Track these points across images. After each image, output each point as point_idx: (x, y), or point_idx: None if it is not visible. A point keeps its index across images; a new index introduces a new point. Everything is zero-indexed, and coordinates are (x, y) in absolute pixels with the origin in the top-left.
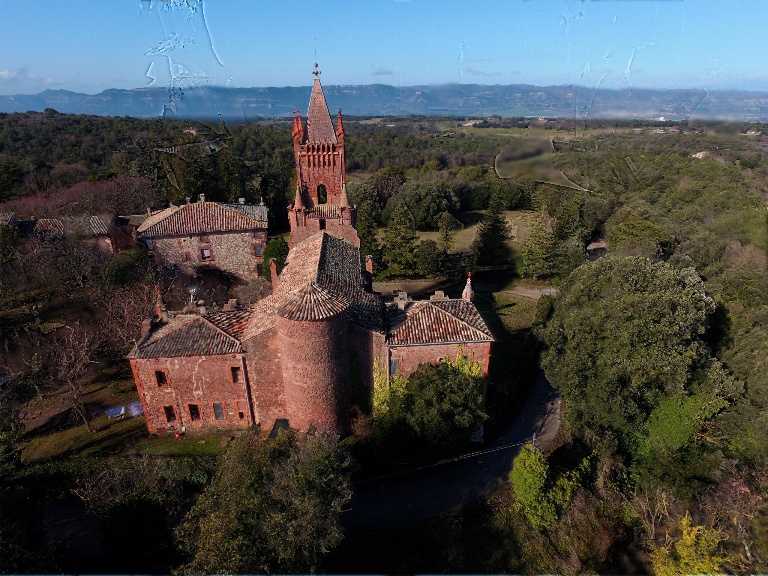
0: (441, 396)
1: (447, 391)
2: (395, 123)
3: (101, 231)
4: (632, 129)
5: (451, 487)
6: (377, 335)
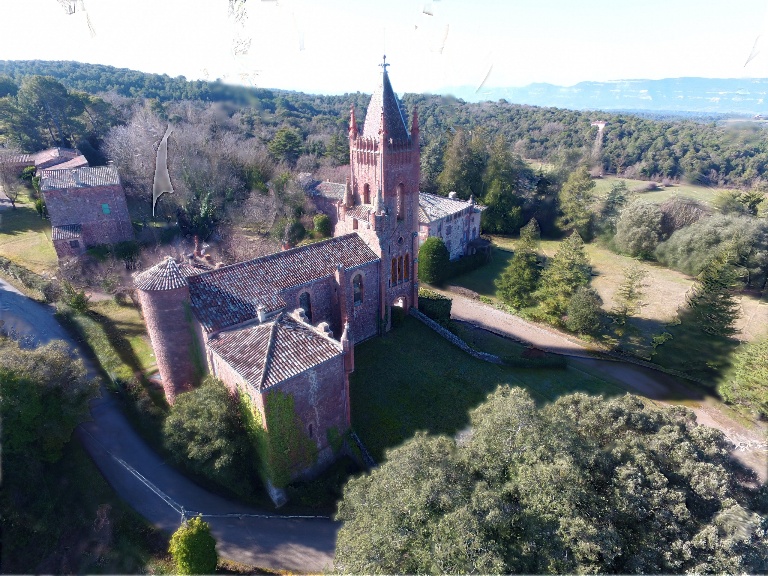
0: (194, 414)
1: None
2: (725, 128)
3: None
4: None
5: (187, 509)
6: None
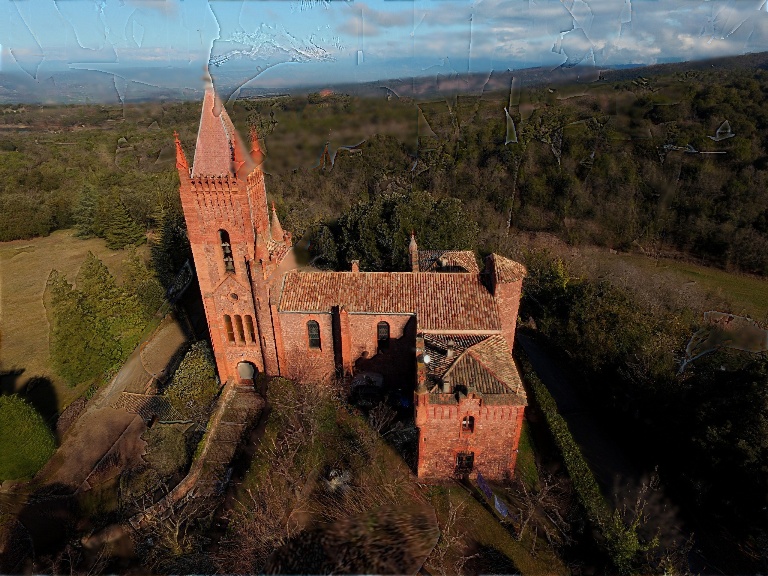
0: None
1: None
2: None
3: None
4: (106, 120)
5: None
6: None
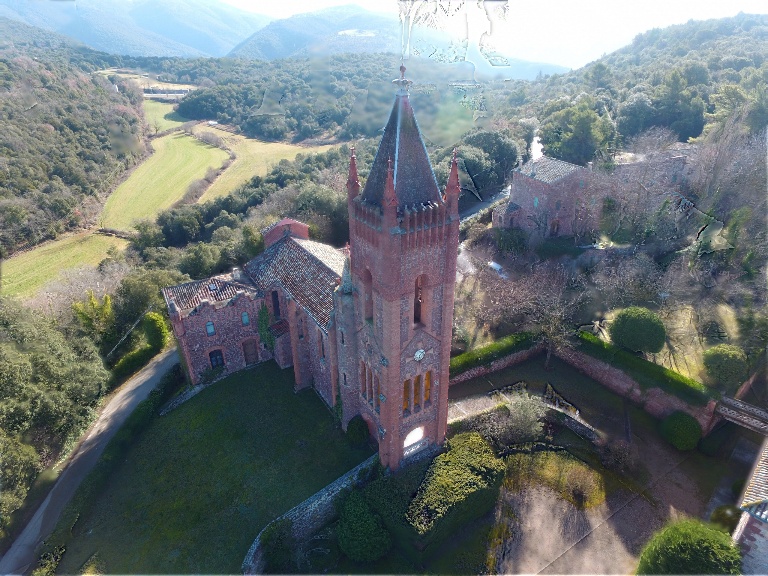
0: None
1: None
2: None
3: None
4: None
5: None
6: None
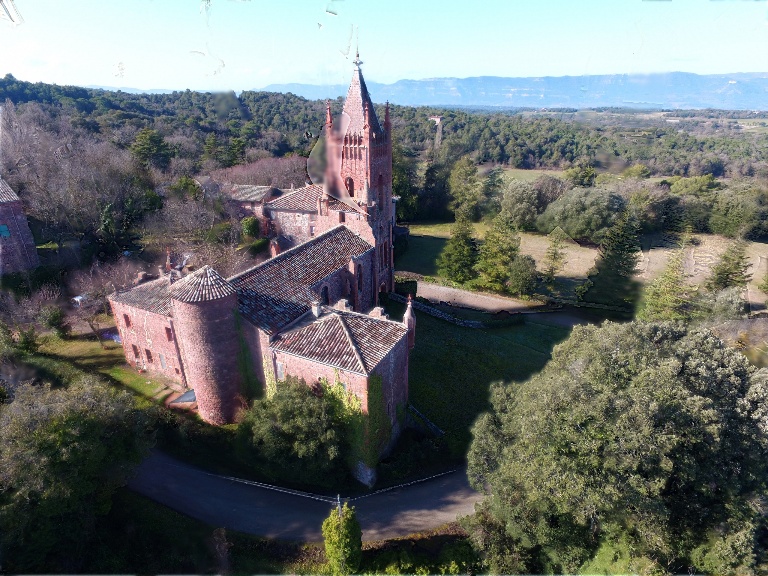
0: (289, 415)
1: (295, 412)
2: (575, 118)
3: (257, 199)
4: None
5: (288, 514)
6: (262, 333)
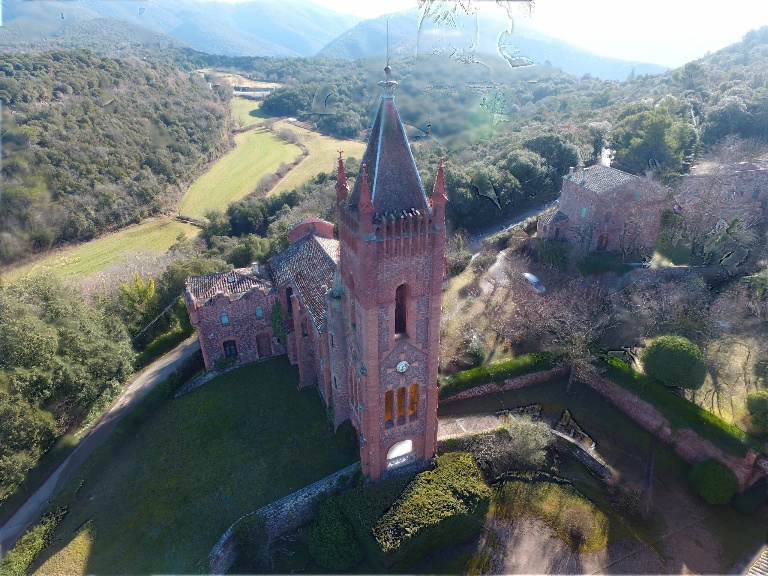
0: None
1: None
2: None
3: None
4: None
5: None
6: None
